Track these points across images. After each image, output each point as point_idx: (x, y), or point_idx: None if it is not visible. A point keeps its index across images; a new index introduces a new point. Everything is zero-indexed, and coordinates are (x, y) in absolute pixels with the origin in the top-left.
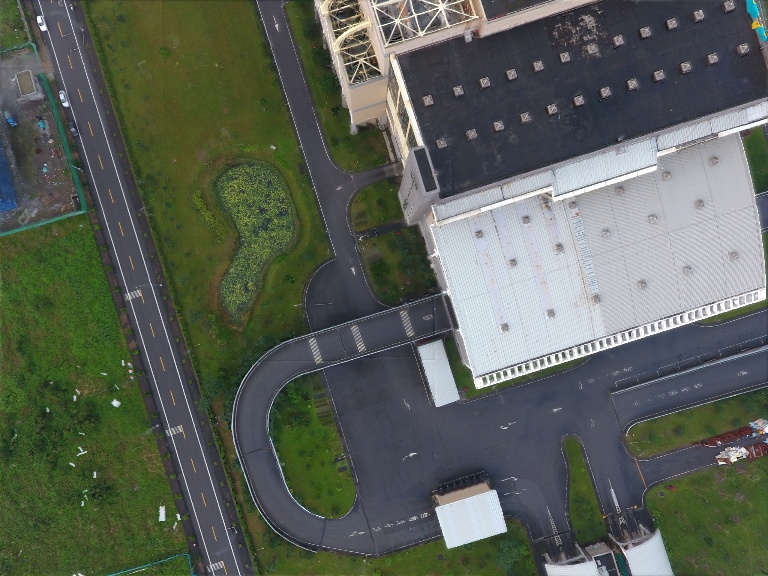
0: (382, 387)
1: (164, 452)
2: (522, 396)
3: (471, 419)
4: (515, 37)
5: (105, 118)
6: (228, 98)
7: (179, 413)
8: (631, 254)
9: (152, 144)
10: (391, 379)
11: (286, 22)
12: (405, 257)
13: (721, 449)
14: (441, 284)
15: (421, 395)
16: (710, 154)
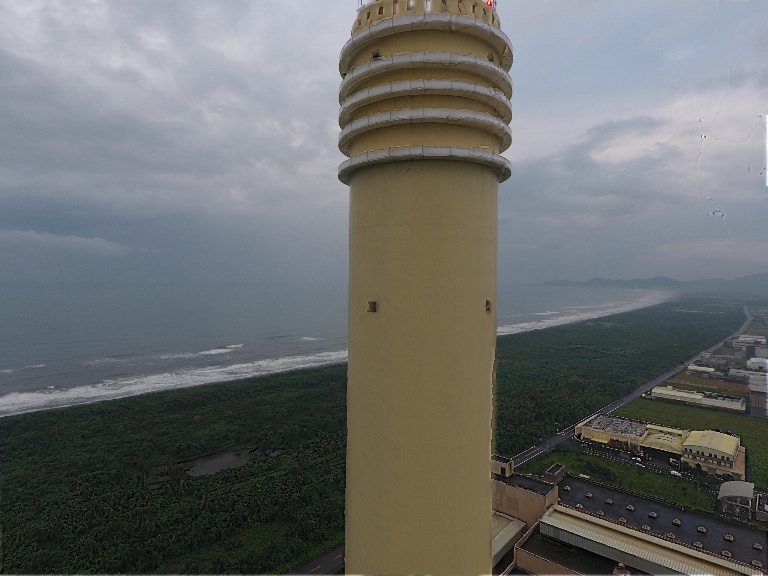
0: None
1: None
2: None
3: None
4: None
5: None
6: None
7: None
8: None
9: None
10: None
11: None
12: None
13: None
14: None
15: None
16: None
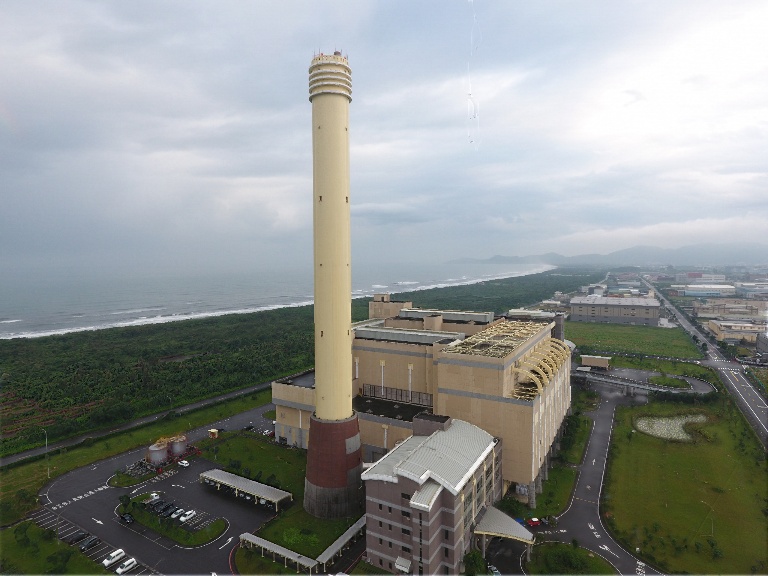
0: None
1: None
2: None
3: None
4: None
5: None
6: (661, 456)
7: (760, 409)
8: None
9: None
10: None
11: None
12: None
13: None
14: None
15: None
16: None
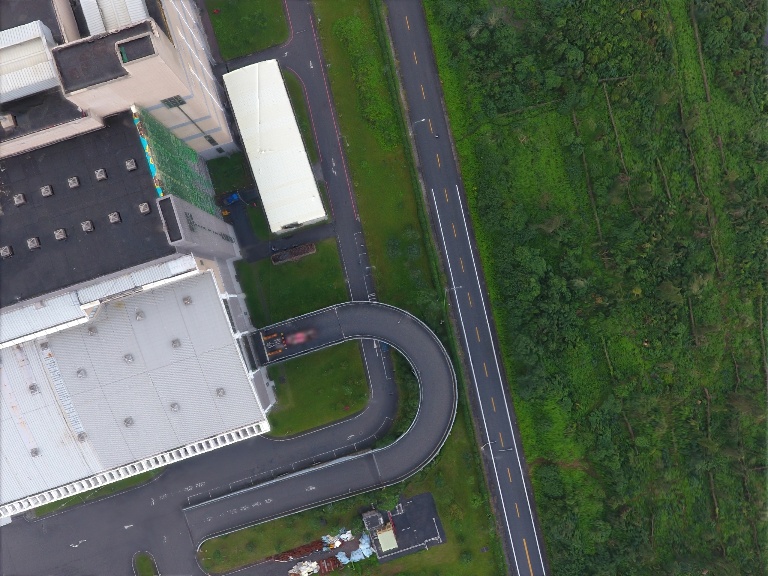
0: None
1: None
2: (93, 513)
3: (41, 537)
4: None
5: None
6: None
7: None
8: (112, 393)
9: None
10: None
11: None
12: None
13: (294, 564)
14: None
15: None
16: (185, 294)
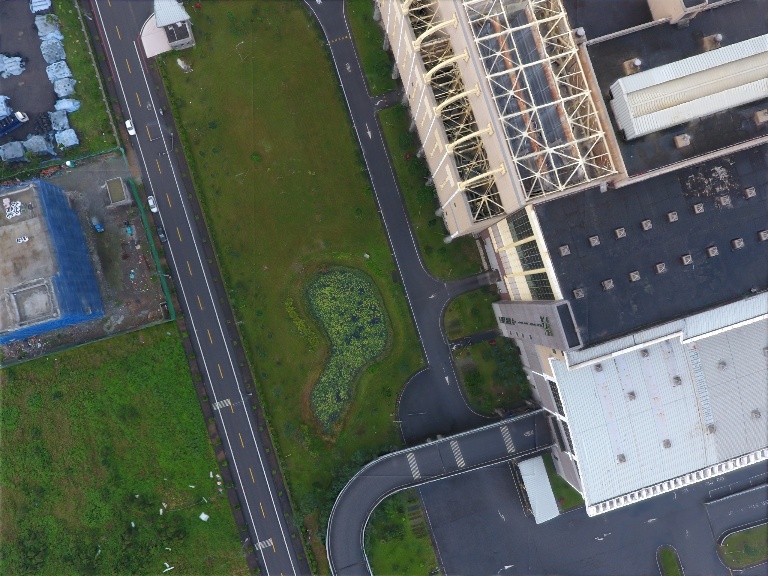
0: (477, 498)
1: (253, 567)
2: None
3: (566, 530)
4: (649, 187)
5: (194, 223)
6: (320, 205)
7: (269, 526)
8: (746, 385)
9: (242, 250)
10: (486, 490)
11: (379, 129)
12: (501, 368)
13: None
14: (542, 400)
15: (516, 506)
16: None
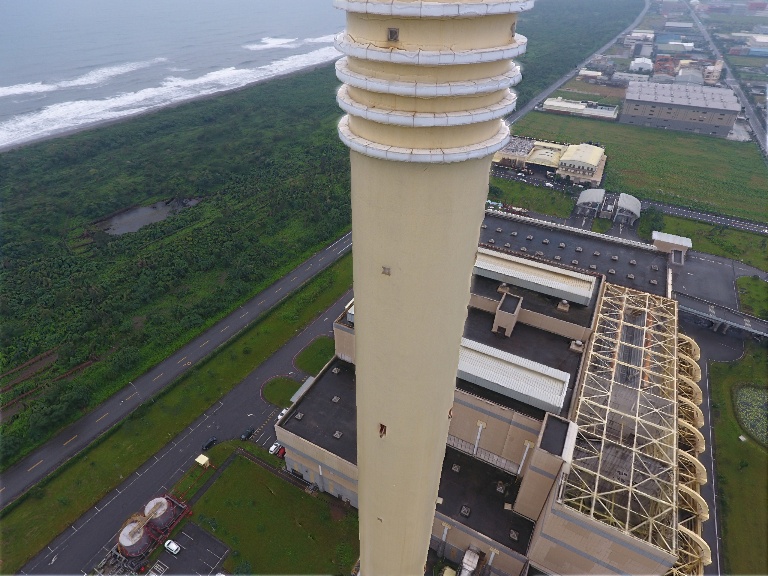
0: None
1: None
2: None
3: None
4: None
5: None
6: None
7: None
8: None
9: None
10: None
11: None
12: None
13: None
14: None
15: None
16: None
